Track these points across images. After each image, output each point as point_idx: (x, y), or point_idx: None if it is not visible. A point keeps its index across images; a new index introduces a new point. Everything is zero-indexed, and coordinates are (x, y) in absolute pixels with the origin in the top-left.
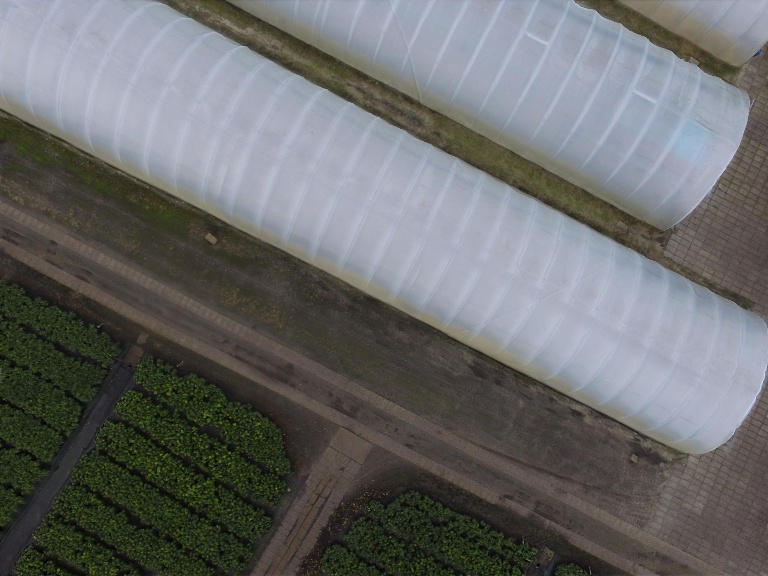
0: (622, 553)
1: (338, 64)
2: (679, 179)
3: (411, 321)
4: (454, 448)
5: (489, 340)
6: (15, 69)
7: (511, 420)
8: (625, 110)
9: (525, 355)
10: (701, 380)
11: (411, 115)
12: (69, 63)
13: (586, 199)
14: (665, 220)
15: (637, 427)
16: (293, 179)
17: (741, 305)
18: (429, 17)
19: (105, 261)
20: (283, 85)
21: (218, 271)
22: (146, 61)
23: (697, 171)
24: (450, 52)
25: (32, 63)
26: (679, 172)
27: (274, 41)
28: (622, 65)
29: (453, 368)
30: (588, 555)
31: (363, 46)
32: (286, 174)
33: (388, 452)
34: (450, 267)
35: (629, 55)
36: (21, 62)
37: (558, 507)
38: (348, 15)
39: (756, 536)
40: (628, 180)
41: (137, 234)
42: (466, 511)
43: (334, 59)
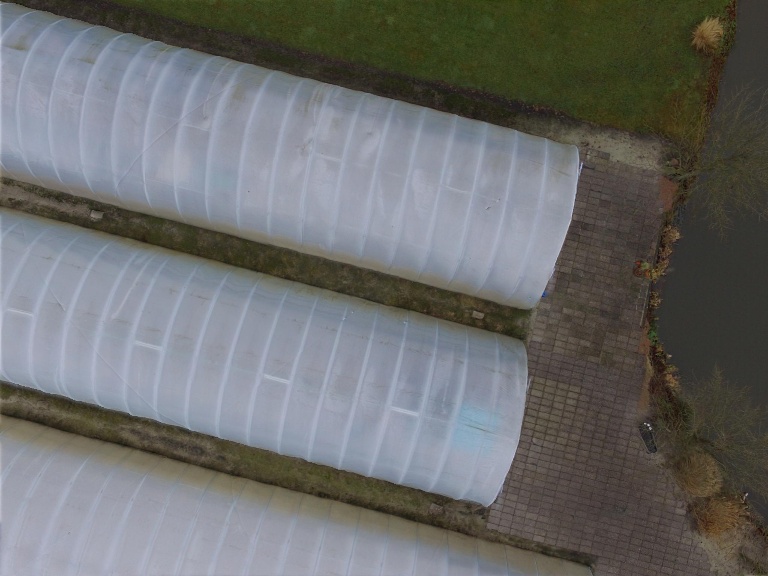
0: None
1: (107, 411)
2: (466, 482)
3: None
4: None
5: None
6: None
7: None
8: (386, 432)
9: None
10: None
11: (192, 444)
12: None
13: (391, 488)
14: None
15: None
16: None
17: (583, 562)
18: (161, 383)
19: None
20: (36, 482)
21: None
22: None
23: (481, 473)
24: (194, 408)
25: None
26: (463, 476)
27: (39, 403)
28: (373, 385)
29: None
30: None
31: (116, 405)
32: None
33: None
34: None
35: (380, 370)
36: None
37: None
38: (87, 390)
39: None
40: (419, 481)
41: None
42: None
43: (101, 407)
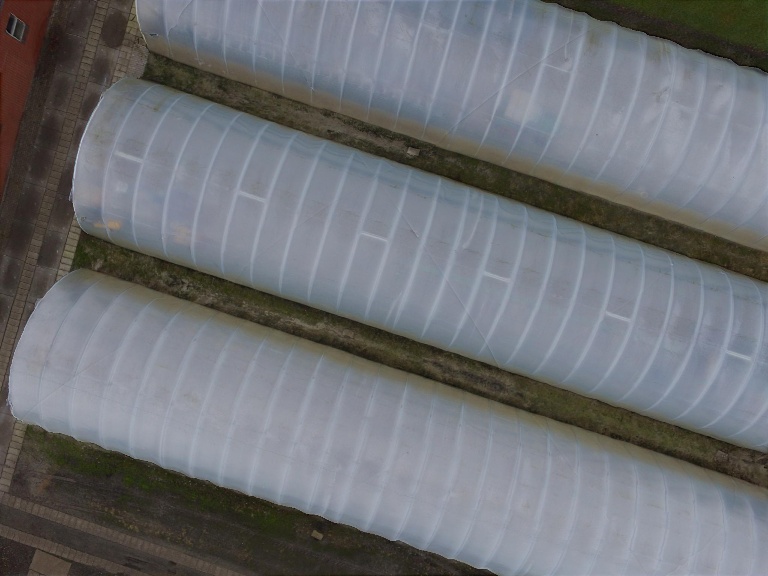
0: None
1: (411, 343)
2: None
3: None
4: None
5: None
6: (117, 435)
7: None
8: (719, 373)
9: None
10: None
11: (491, 380)
12: (167, 427)
13: (681, 434)
14: None
15: None
16: (396, 501)
17: None
18: (504, 314)
19: (222, 573)
20: (370, 402)
21: (329, 565)
22: (239, 413)
23: None
24: (529, 341)
25: (133, 430)
26: None
27: (345, 331)
28: (710, 328)
29: None
30: None
31: (437, 336)
32: (389, 497)
33: None
34: (563, 560)
35: (715, 314)
36: (122, 430)
37: None
38: (421, 317)
39: None
40: (727, 426)
41: (247, 542)
42: None
43: (407, 339)
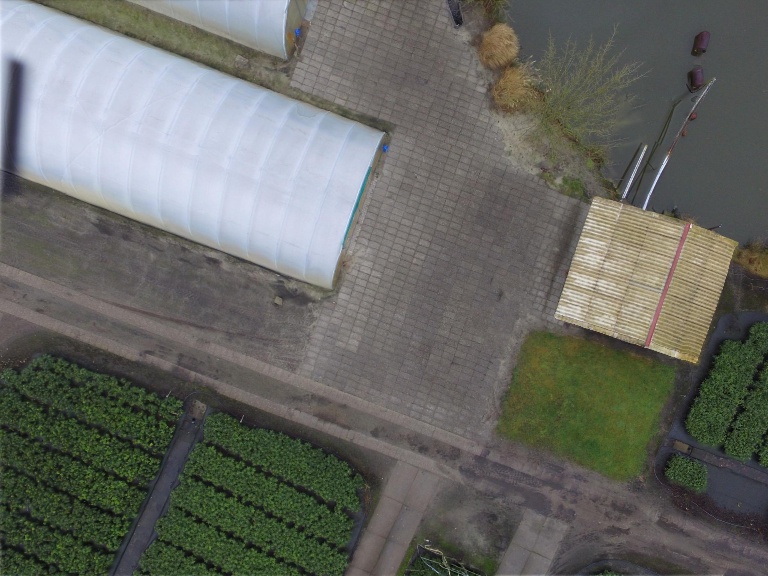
0: (275, 398)
1: None
2: None
3: (28, 184)
4: (86, 308)
5: (86, 188)
6: None
7: (143, 274)
8: None
9: (122, 198)
10: (291, 197)
11: None
12: None
13: (199, 36)
14: (281, 46)
15: (273, 267)
16: None
17: (381, 129)
18: None
19: None
20: None
21: None
22: None
23: None
24: None
25: None
26: None
27: None
28: None
29: (76, 227)
30: (239, 404)
31: None
32: None
33: (19, 319)
34: (10, 109)
35: None
36: None
37: (202, 358)
38: None
39: (419, 369)
40: (216, 2)
41: None
42: (108, 371)
43: None
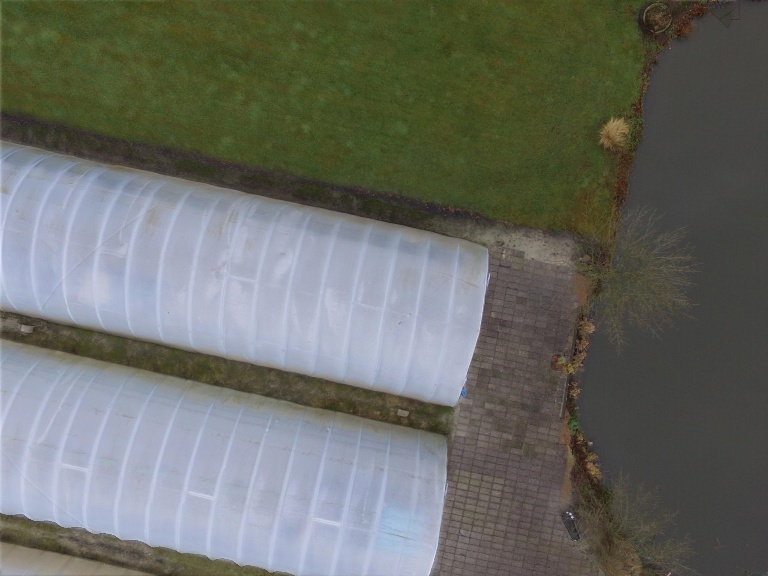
0: None
1: (44, 521)
2: None
3: None
4: None
5: None
6: None
7: None
8: (310, 542)
9: None
10: None
11: (129, 549)
12: None
13: None
14: None
15: None
16: None
17: None
18: (89, 504)
19: None
20: None
21: None
22: None
23: None
24: (123, 525)
25: None
26: None
27: None
28: (295, 498)
29: None
30: None
31: (50, 520)
32: None
33: None
34: None
35: (301, 482)
36: None
37: None
38: (18, 510)
39: None
40: None
41: None
42: None
43: None
